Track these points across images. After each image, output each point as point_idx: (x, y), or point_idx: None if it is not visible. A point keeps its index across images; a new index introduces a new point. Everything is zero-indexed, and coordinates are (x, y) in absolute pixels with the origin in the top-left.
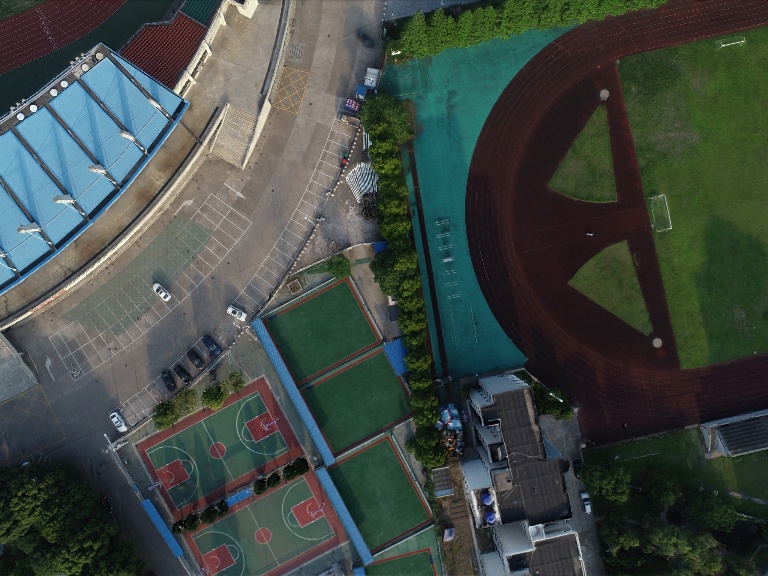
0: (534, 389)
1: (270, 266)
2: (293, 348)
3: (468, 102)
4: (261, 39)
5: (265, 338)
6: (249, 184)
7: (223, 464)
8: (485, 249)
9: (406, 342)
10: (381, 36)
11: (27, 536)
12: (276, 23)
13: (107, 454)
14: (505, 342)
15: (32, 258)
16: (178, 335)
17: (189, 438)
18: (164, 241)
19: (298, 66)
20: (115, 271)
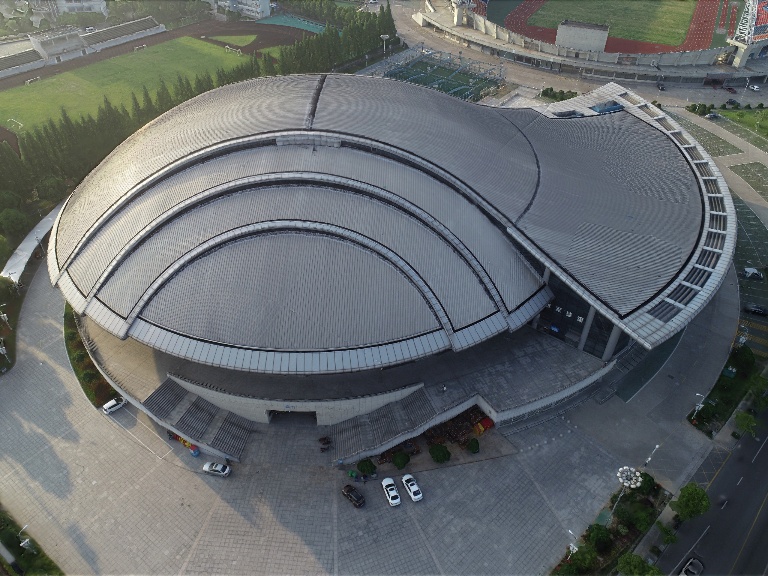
0: None
1: None
2: None
3: None
4: None
5: None
6: None
7: None
8: None
9: None
10: None
11: None
12: None
13: None
14: None
15: None
16: None
17: None
18: (417, 4)
19: None
20: None
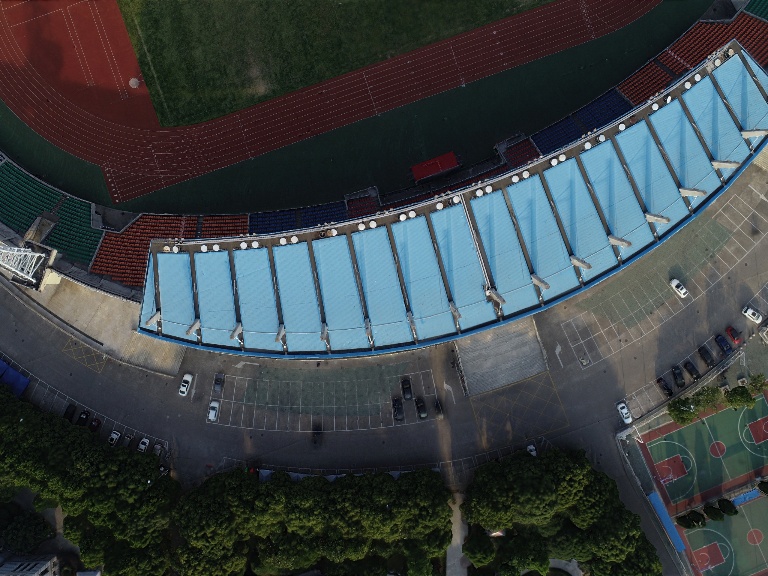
0: None
1: None
2: None
3: None
4: None
5: None
6: None
7: (722, 463)
8: None
9: None
10: None
11: (553, 519)
12: None
13: (608, 444)
14: None
15: (637, 247)
16: (690, 332)
17: (690, 435)
18: (684, 238)
19: None
20: (632, 264)
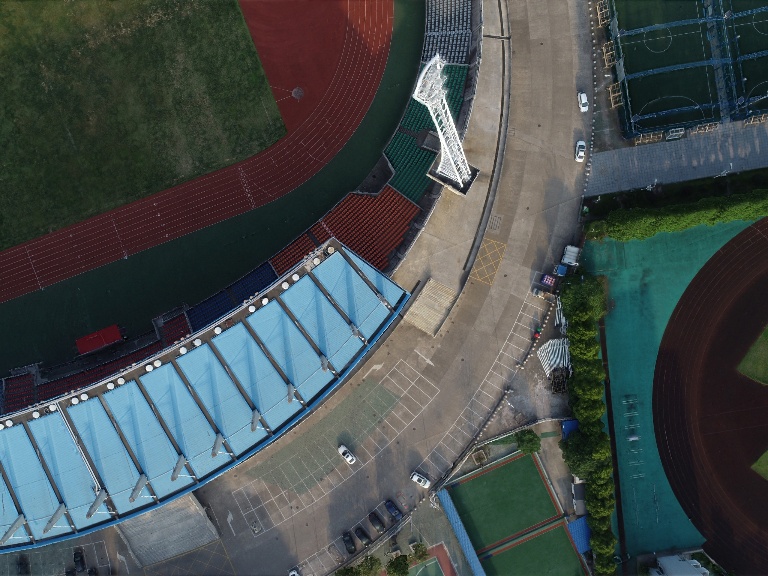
0: (711, 571)
1: (455, 434)
2: (474, 517)
3: (662, 281)
4: (467, 215)
5: (450, 509)
6: (439, 352)
7: None
8: (670, 428)
9: (594, 525)
10: (581, 212)
11: None
12: (483, 200)
13: None
14: (684, 522)
15: (250, 443)
16: (360, 498)
17: None
18: (351, 404)
19: (495, 237)
20: (301, 431)
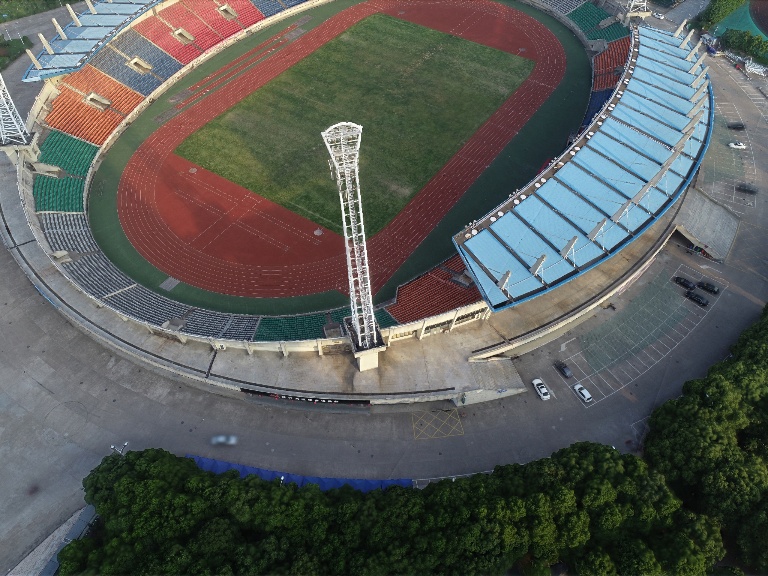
0: None
1: (767, 114)
2: None
3: None
4: None
5: None
6: None
7: None
8: None
9: None
10: (687, 29)
11: None
12: None
13: None
14: None
15: (706, 100)
16: None
17: None
18: None
19: None
20: None
